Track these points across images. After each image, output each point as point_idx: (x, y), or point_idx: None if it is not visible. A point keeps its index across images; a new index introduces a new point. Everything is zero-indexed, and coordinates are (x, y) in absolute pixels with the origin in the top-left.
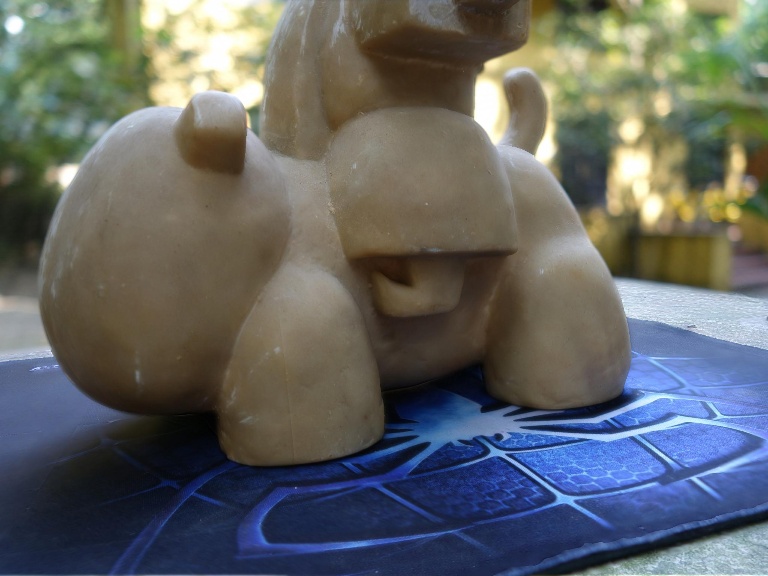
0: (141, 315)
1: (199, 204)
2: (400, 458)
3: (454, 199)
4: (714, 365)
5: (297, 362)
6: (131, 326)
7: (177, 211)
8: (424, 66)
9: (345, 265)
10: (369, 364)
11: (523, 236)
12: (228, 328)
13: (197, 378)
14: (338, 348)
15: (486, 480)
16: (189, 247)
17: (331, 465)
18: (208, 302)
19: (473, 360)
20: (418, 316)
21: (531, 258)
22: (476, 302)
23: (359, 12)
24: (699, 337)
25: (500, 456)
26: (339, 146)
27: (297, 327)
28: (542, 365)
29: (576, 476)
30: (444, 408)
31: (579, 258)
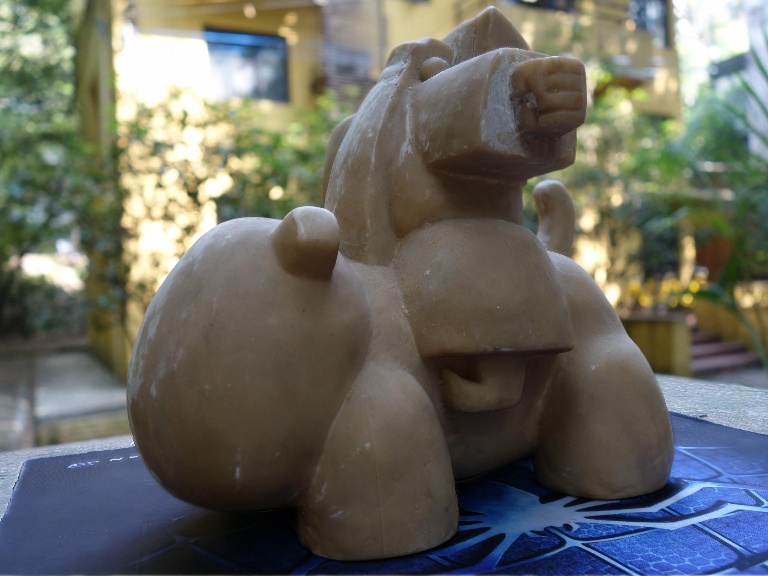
0: (245, 414)
1: (297, 309)
2: (482, 550)
3: (521, 303)
4: (742, 454)
5: (386, 457)
6: (235, 424)
7: (278, 315)
8: (482, 182)
9: (419, 363)
10: (446, 458)
11: (573, 335)
12: (321, 425)
13: (292, 474)
14: (422, 443)
15: (574, 569)
16: (289, 349)
17: (418, 558)
18: (305, 400)
19: (525, 452)
20: (486, 411)
21: (581, 355)
22: (531, 397)
23: (427, 136)
24: (716, 426)
25: (577, 546)
26: (408, 253)
27: (385, 423)
28: (598, 456)
29: (657, 563)
30: (504, 500)
31: (625, 355)
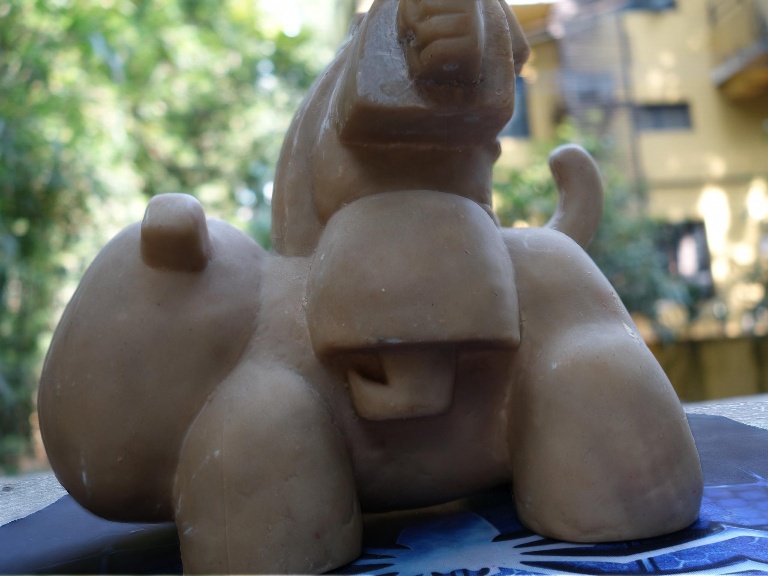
0: (86, 414)
1: (151, 302)
2: None
3: (417, 283)
4: None
5: (236, 467)
6: (78, 425)
7: (128, 310)
8: (408, 150)
9: (315, 363)
10: (329, 473)
11: (536, 325)
12: (173, 429)
13: (142, 482)
14: (284, 453)
15: None
16: (135, 345)
17: None
18: (151, 401)
19: (500, 477)
20: (395, 419)
21: (545, 351)
22: (486, 405)
23: (337, 106)
24: None
25: None
26: (321, 239)
27: (240, 428)
28: (557, 483)
29: None
30: (454, 534)
31: (604, 348)
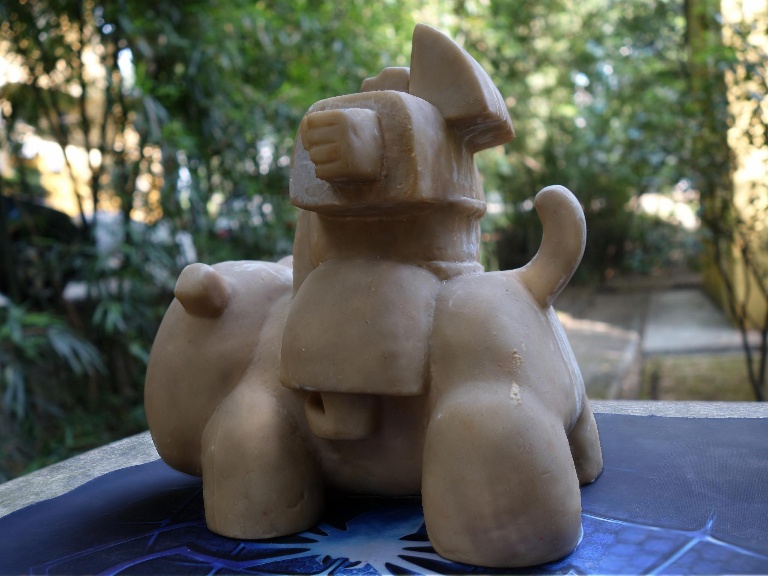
0: (152, 410)
1: (186, 340)
2: (270, 554)
3: (325, 347)
4: (749, 572)
5: (220, 459)
6: None
7: (174, 344)
8: (359, 222)
9: (286, 388)
10: (279, 472)
11: (441, 377)
12: (197, 426)
13: (183, 456)
14: (247, 455)
15: None
16: (175, 369)
17: (234, 543)
18: (183, 407)
19: None
20: (328, 439)
21: (441, 400)
22: (411, 433)
23: None
24: None
25: None
26: None
27: (225, 434)
28: (428, 509)
29: None
30: (387, 525)
31: (476, 408)
